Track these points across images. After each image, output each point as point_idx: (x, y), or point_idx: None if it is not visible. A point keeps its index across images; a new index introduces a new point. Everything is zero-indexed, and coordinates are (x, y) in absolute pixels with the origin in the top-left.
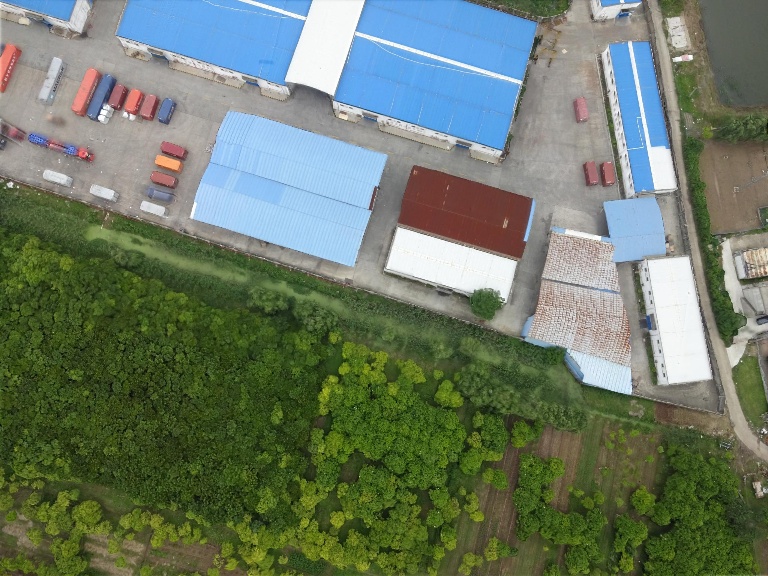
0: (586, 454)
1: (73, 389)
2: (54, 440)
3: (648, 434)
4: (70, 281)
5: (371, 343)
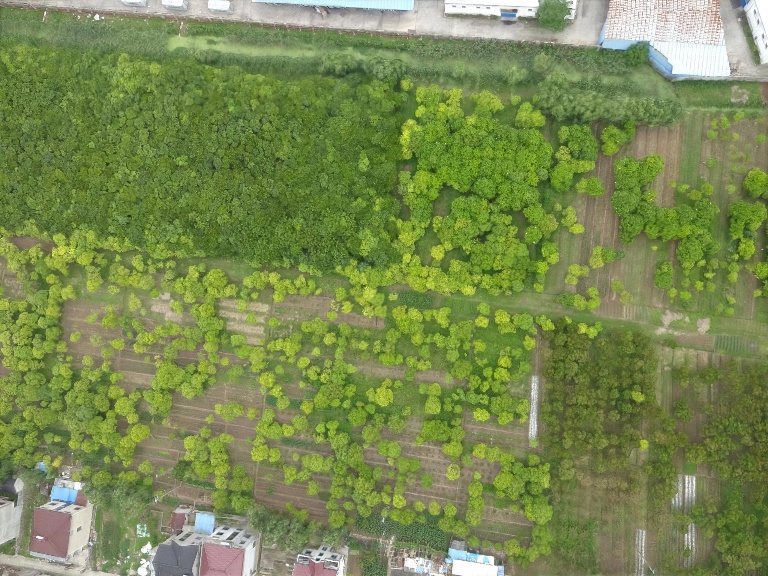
0: (687, 151)
1: (182, 173)
2: (175, 220)
3: (756, 118)
4: (161, 81)
5: (444, 87)
